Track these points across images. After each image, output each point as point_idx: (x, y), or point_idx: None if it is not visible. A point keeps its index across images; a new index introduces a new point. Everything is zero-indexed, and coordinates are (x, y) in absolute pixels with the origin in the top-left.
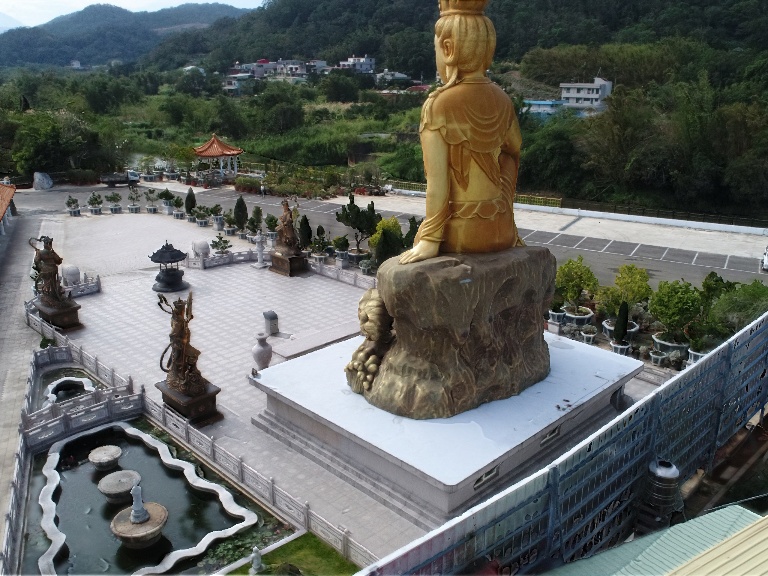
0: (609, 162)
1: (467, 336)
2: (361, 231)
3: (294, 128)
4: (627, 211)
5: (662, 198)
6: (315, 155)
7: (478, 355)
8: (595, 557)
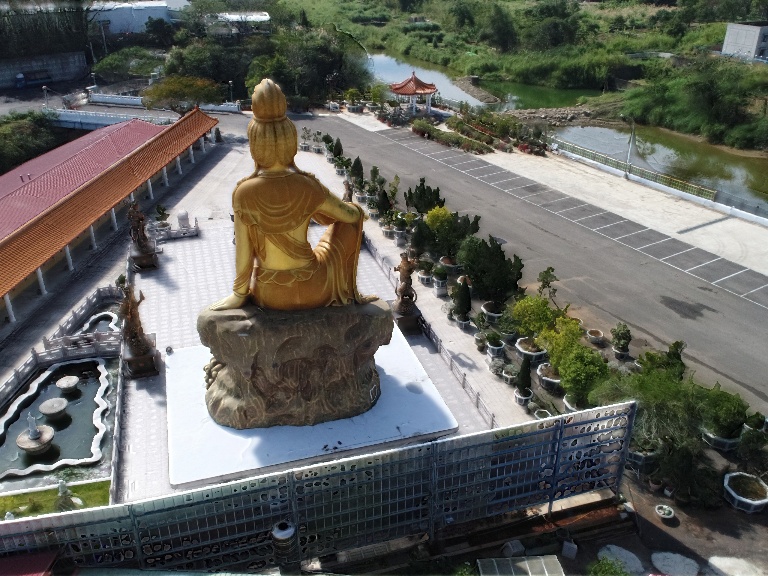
0: None
1: (250, 375)
2: None
3: (559, 45)
4: None
5: None
6: (570, 78)
7: (274, 388)
8: (147, 571)
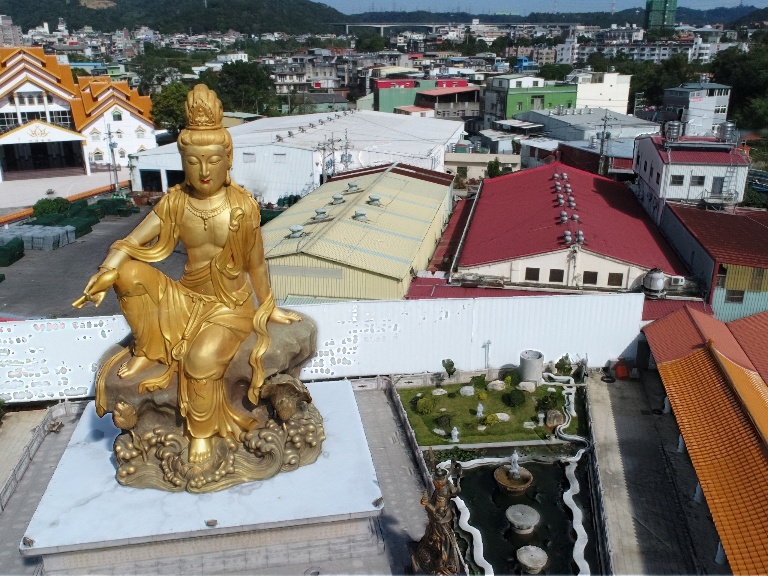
0: None
1: None
2: None
3: None
4: None
5: None
6: None
7: None
8: None
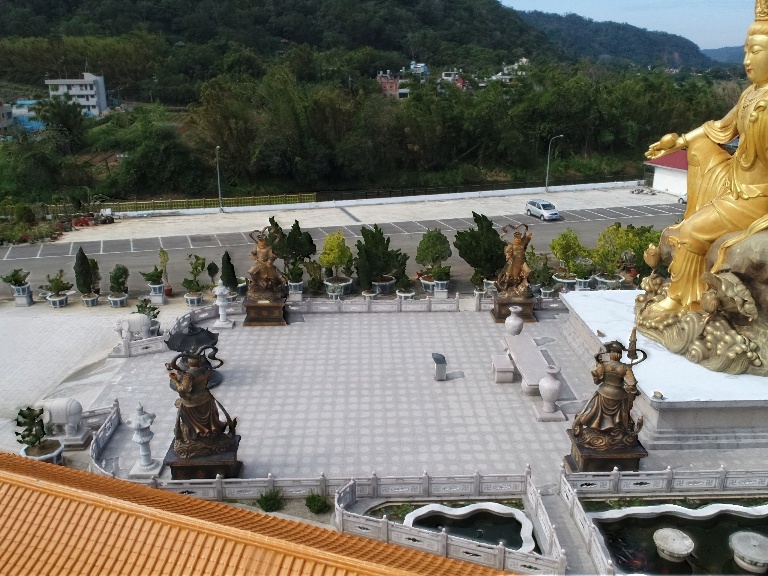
0: (228, 156)
1: None
2: (283, 257)
3: None
4: (377, 195)
5: (283, 184)
6: None
7: None
8: None
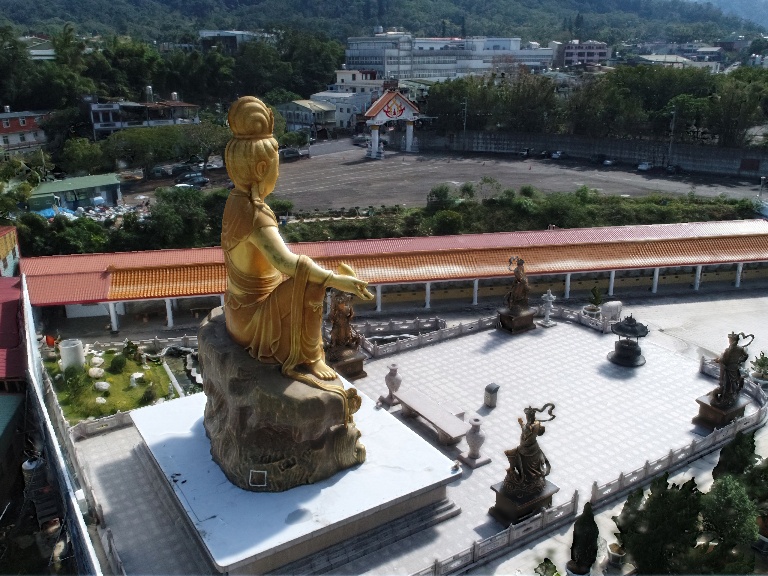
0: None
1: None
2: None
3: None
4: None
5: None
6: None
7: None
8: None
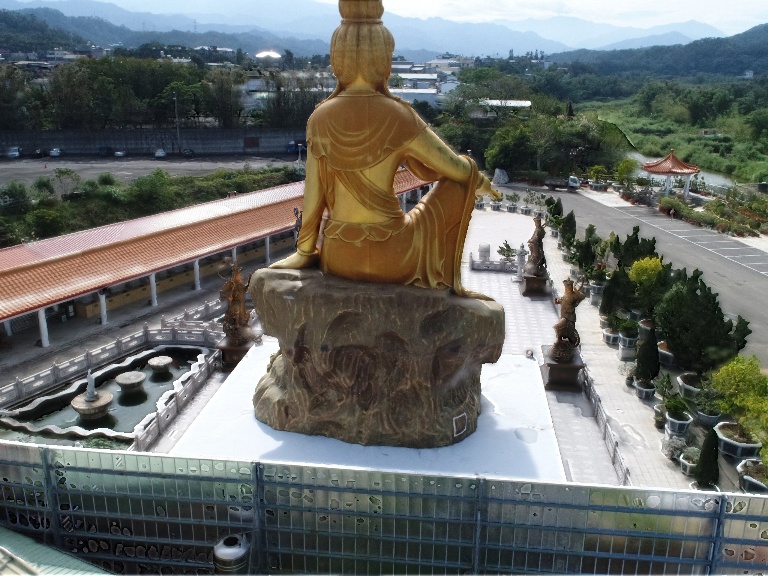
0: None
1: (293, 355)
2: None
3: None
4: None
5: None
6: None
7: (324, 383)
8: (39, 545)
